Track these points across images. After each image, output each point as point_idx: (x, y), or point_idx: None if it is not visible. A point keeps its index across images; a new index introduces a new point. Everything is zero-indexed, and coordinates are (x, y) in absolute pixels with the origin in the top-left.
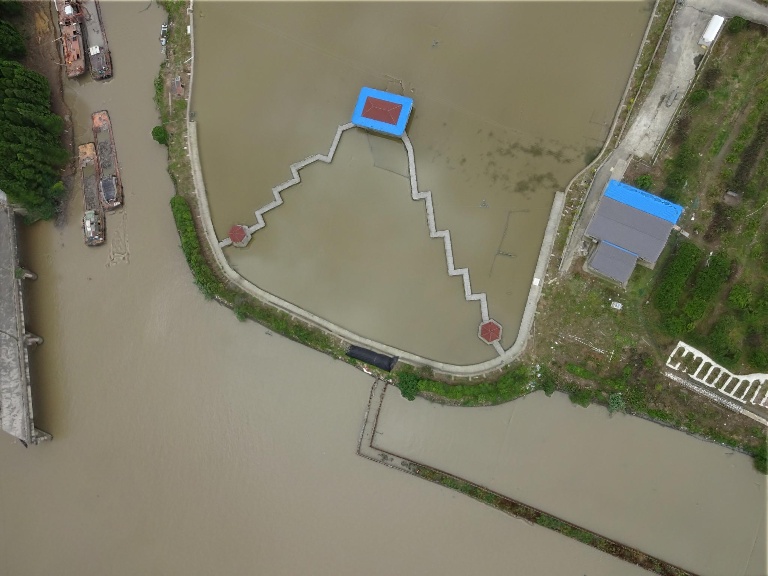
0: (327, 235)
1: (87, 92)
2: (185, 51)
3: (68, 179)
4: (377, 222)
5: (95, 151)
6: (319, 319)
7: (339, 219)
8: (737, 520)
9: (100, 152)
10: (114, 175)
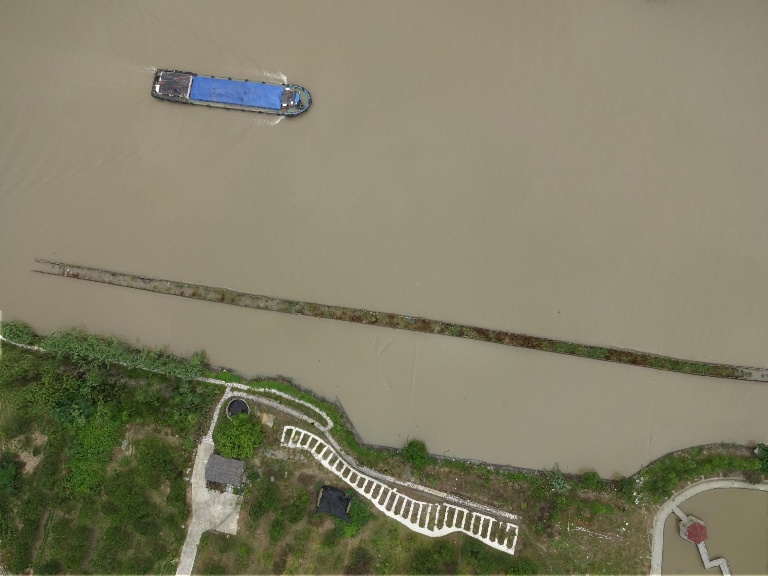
0: None
1: None
2: None
3: None
4: None
5: None
6: None
7: None
8: (430, 392)
9: None
10: None
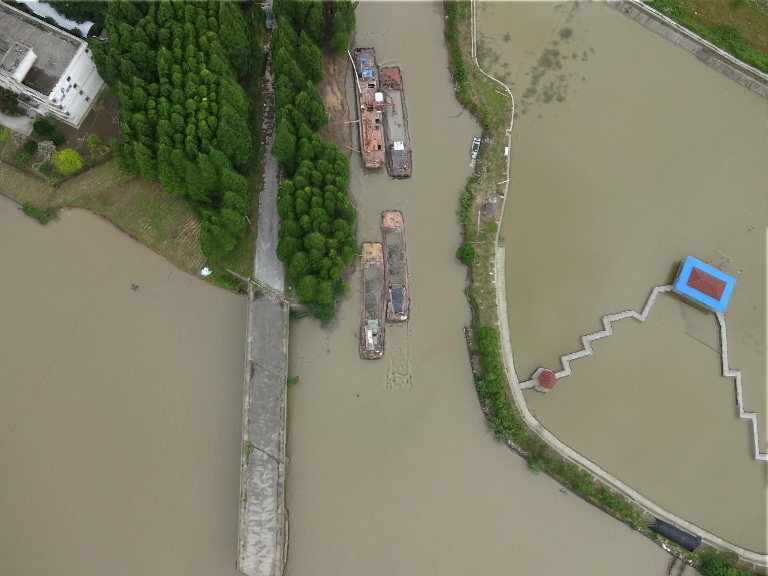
0: (632, 395)
1: (372, 184)
2: (500, 172)
3: (346, 278)
4: (684, 391)
5: (382, 253)
6: (622, 484)
7: (645, 380)
8: None
9: (388, 256)
10: (404, 285)
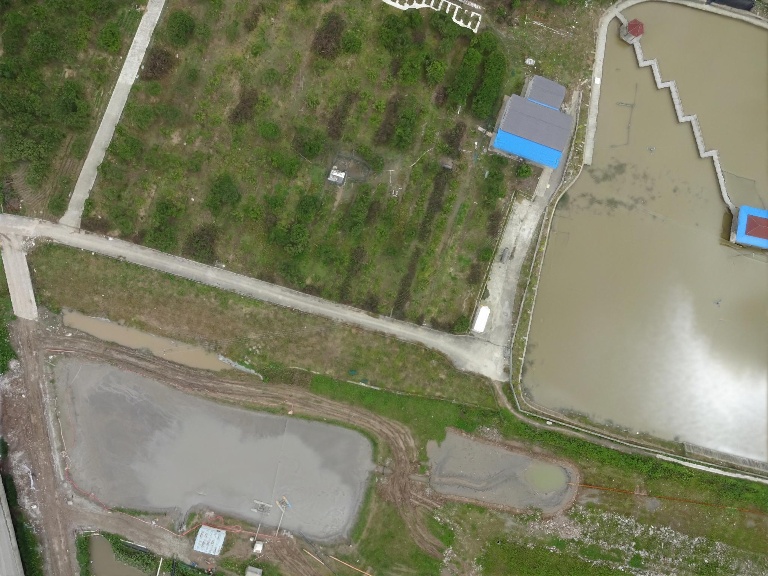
0: None
1: None
2: None
3: None
4: (742, 129)
5: None
6: None
7: None
8: None
9: None
10: None
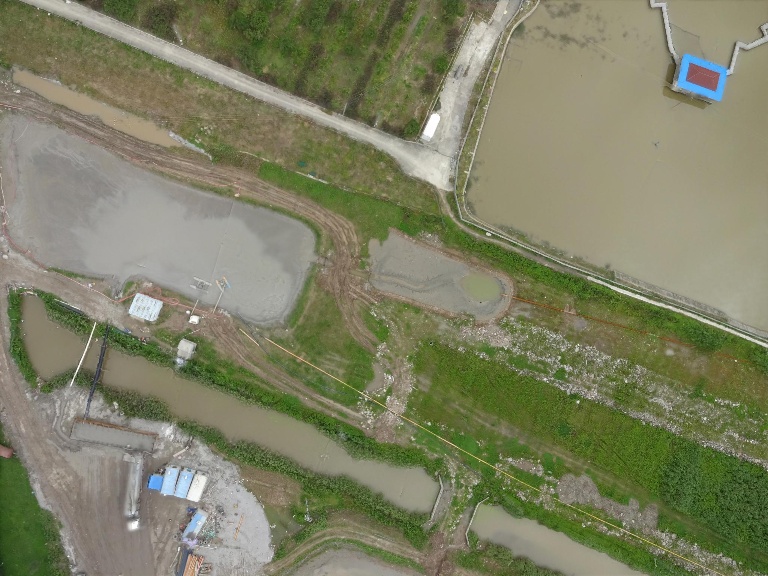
0: None
1: None
2: None
3: None
4: None
5: None
6: None
7: None
8: None
9: None
10: None
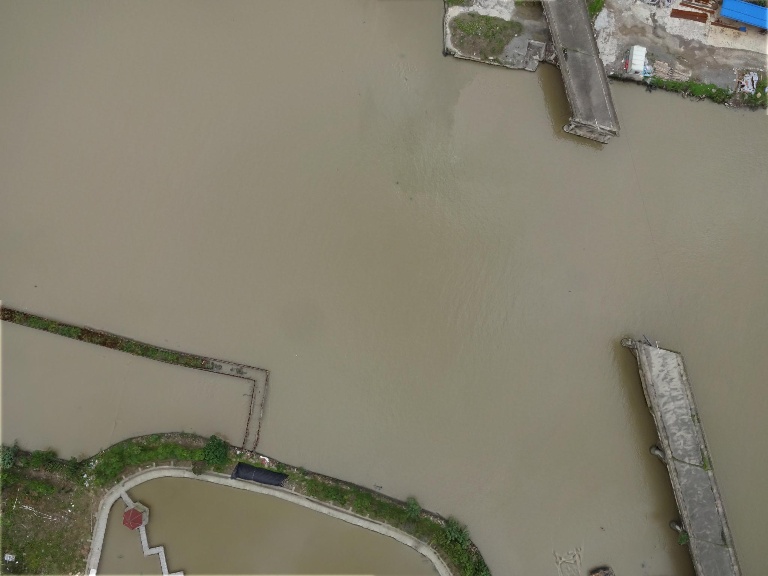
0: None
1: None
2: None
3: None
4: None
5: None
6: (322, 510)
7: None
8: None
9: None
10: None
